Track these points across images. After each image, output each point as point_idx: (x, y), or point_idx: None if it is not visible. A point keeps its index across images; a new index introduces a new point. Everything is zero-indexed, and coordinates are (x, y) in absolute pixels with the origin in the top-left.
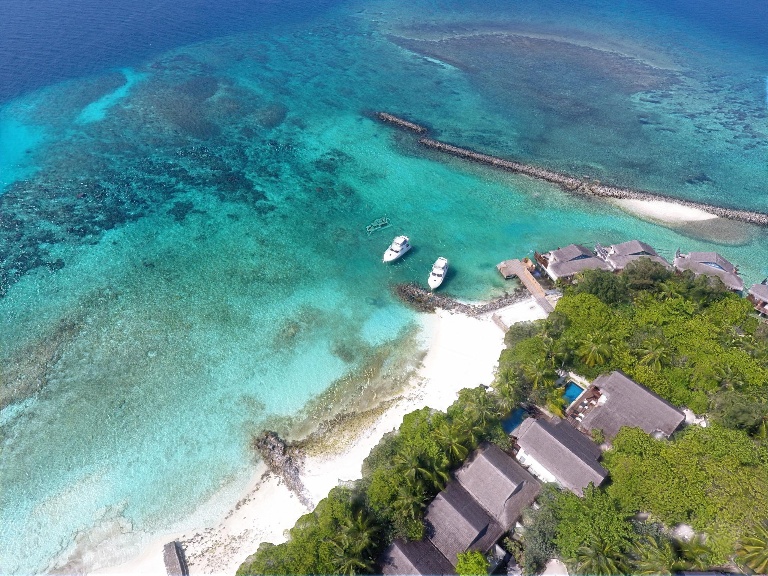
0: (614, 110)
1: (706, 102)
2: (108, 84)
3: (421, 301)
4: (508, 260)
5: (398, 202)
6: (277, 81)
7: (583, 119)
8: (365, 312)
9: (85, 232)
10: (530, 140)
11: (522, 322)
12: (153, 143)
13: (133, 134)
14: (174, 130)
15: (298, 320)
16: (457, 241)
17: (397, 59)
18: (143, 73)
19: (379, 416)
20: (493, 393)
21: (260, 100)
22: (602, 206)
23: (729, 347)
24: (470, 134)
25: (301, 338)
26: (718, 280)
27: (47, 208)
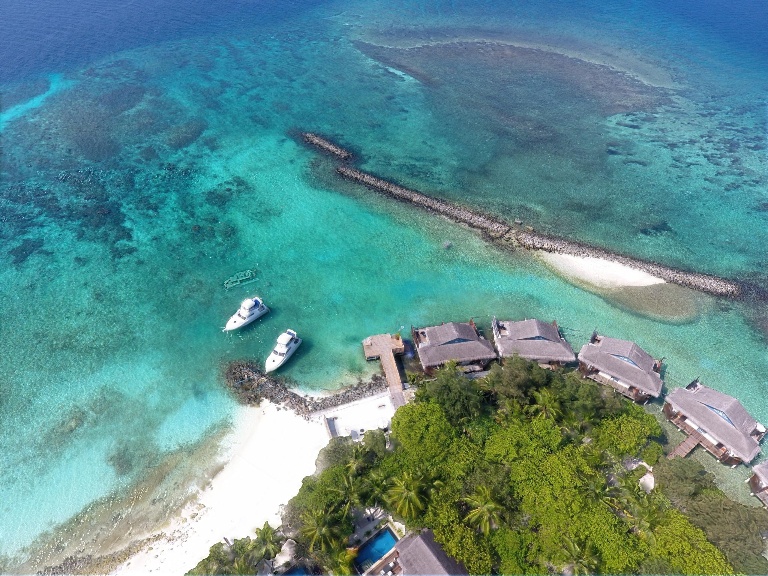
0: (581, 136)
1: (695, 128)
2: (27, 92)
3: (249, 388)
4: (377, 335)
5: (281, 248)
6: (211, 92)
7: (541, 146)
8: (175, 400)
9: None
10: (468, 171)
11: (341, 438)
12: (37, 164)
13: (21, 152)
14: (68, 149)
15: (88, 408)
16: (330, 303)
17: (355, 69)
18: (71, 80)
19: (120, 564)
20: (231, 567)
21: (181, 115)
22: (525, 262)
23: (601, 497)
24: (401, 162)
25: (79, 435)
26: (611, 393)
27: None
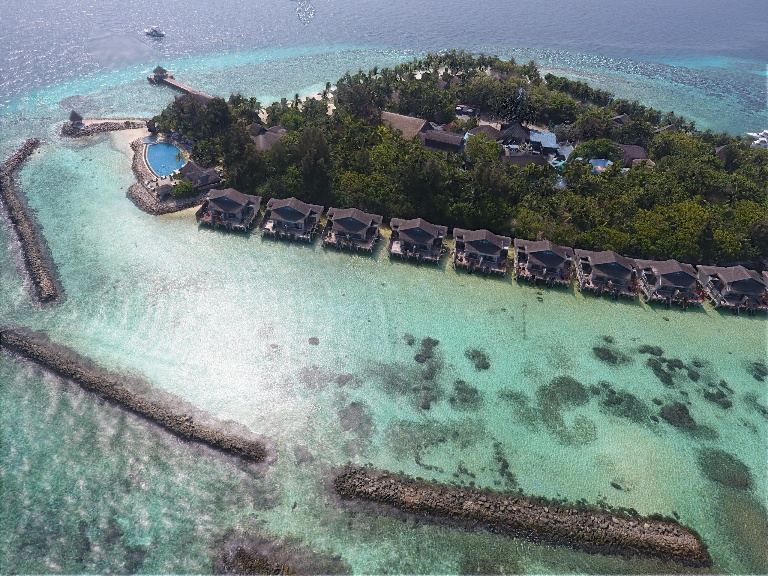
0: None
1: None
2: None
3: None
4: None
5: None
6: None
7: None
8: None
9: (674, 80)
10: None
11: None
12: (760, 86)
13: (761, 82)
14: None
15: (679, 116)
16: None
17: None
18: None
19: None
20: None
21: None
22: None
23: None
24: None
25: None
26: None
27: (678, 73)
